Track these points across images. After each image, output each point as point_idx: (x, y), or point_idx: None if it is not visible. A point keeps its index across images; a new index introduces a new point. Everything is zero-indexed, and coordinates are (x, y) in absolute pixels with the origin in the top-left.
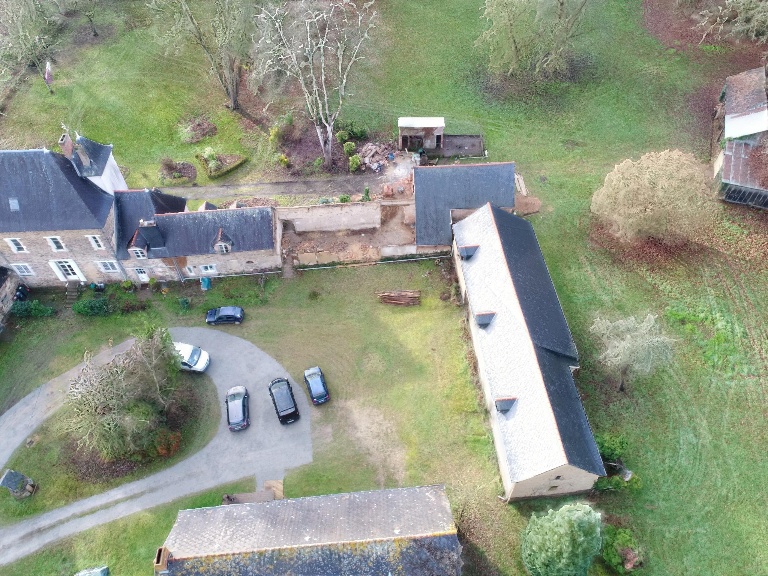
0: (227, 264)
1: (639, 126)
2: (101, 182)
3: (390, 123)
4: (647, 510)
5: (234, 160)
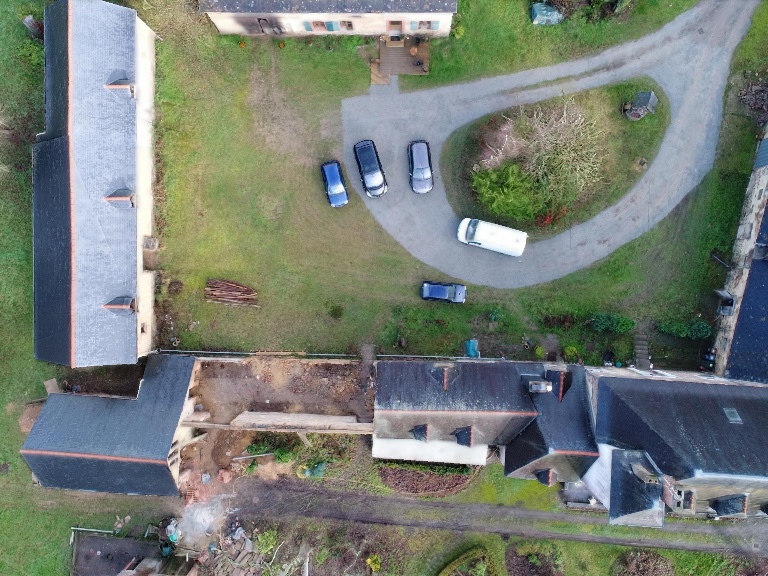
0: None
1: None
2: None
3: None
4: (27, 6)
5: None
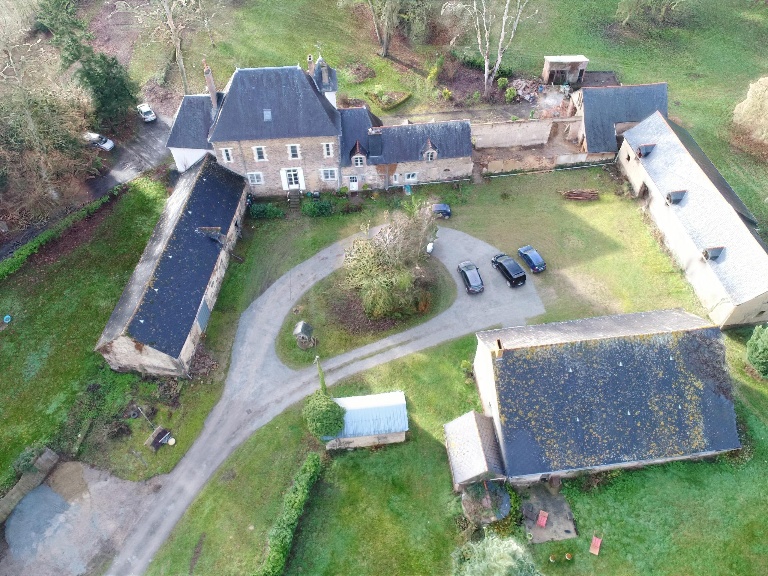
0: (428, 172)
1: (749, 61)
2: (333, 98)
3: (529, 64)
4: None
5: (400, 95)
